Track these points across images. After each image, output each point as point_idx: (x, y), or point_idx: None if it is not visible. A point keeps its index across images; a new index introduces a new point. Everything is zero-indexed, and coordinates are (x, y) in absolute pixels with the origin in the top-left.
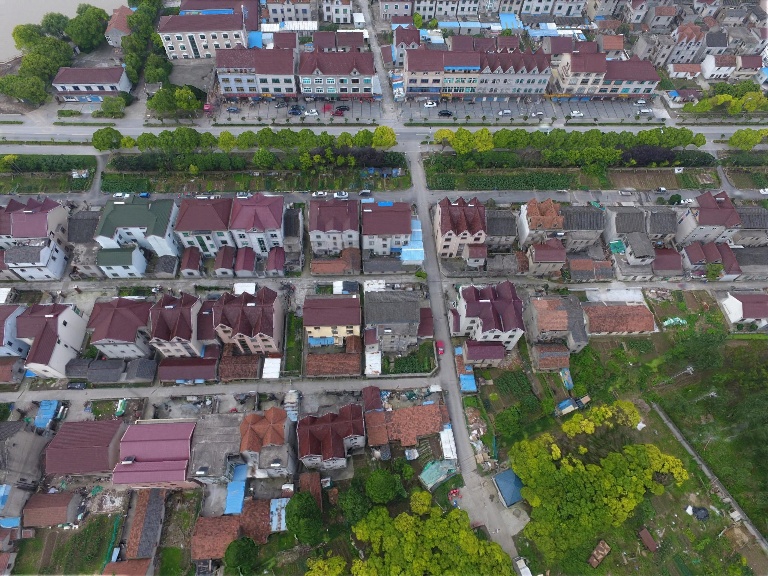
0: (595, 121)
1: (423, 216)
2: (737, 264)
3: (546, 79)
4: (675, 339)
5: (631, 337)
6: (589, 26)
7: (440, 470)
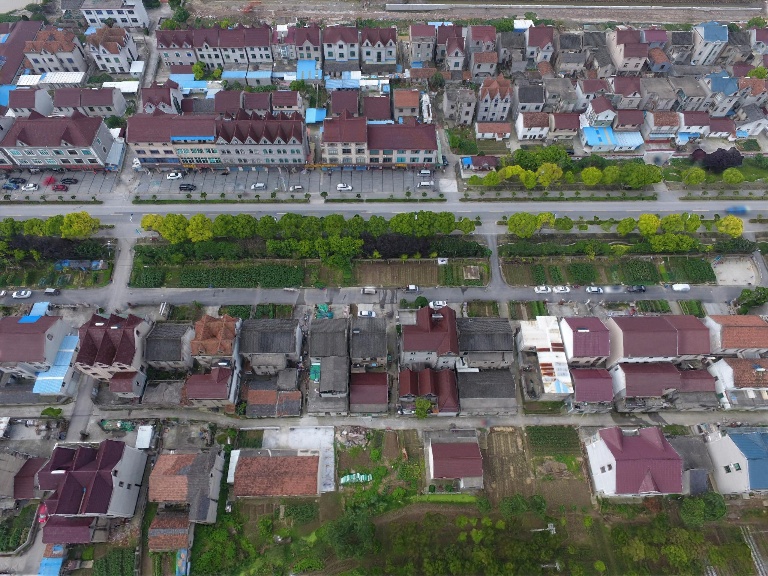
0: (361, 197)
1: None
2: (452, 400)
3: (299, 149)
4: (347, 503)
5: (295, 498)
6: (400, 75)
7: None
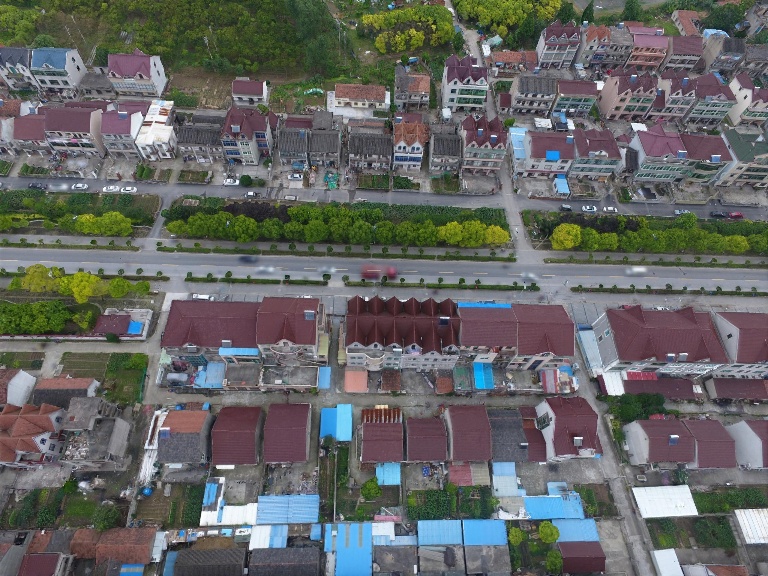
0: None
1: (507, 183)
2: None
3: None
4: None
5: None
6: (175, 539)
7: (492, 42)
